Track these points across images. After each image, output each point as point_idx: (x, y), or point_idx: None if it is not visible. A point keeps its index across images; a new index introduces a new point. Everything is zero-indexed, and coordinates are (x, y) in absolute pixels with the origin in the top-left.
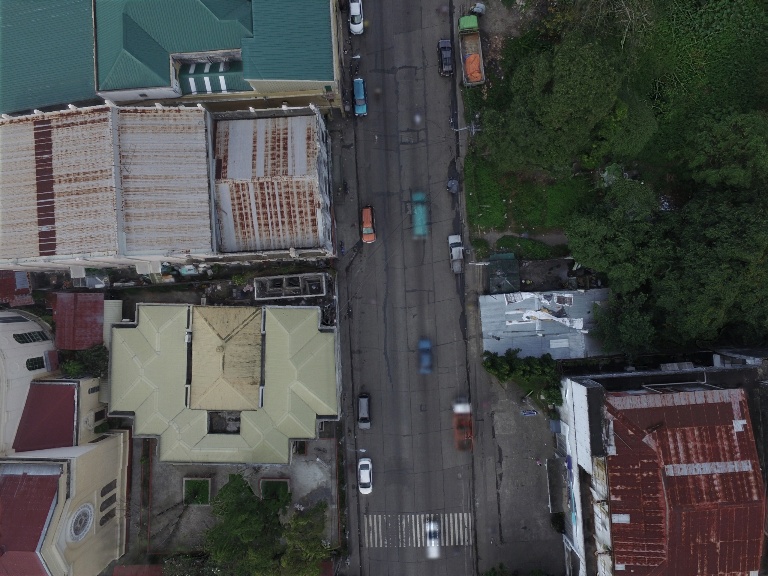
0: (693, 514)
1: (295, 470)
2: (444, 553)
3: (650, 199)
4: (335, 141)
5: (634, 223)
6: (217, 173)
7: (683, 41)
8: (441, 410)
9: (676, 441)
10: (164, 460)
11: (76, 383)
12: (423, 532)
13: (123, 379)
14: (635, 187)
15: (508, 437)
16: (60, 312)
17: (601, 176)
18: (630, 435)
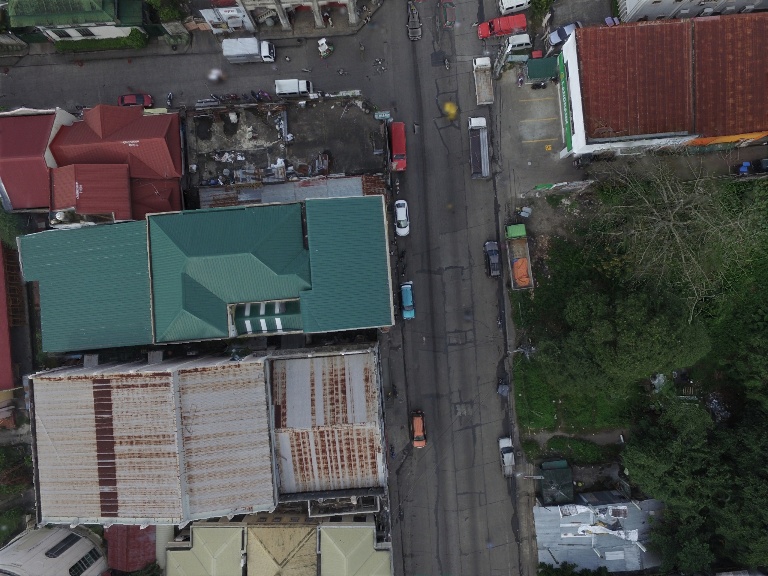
0: None
1: None
2: None
3: (705, 420)
4: (383, 343)
5: (692, 452)
6: (276, 421)
7: (729, 239)
8: None
9: None
10: None
11: None
12: None
13: None
14: (691, 411)
15: None
16: (112, 531)
17: (652, 383)
18: None
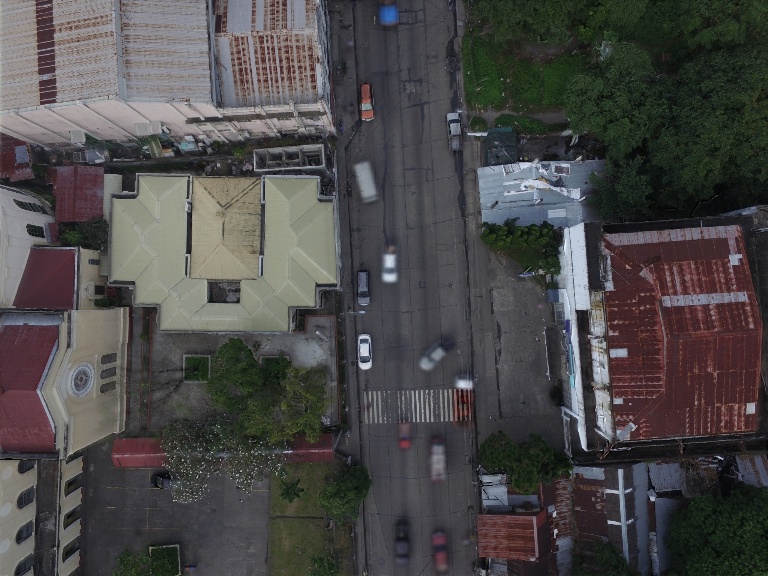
0: (690, 343)
1: (295, 348)
2: (443, 428)
3: (646, 64)
4: (334, 22)
5: (630, 83)
6: (217, 27)
7: None
8: (440, 287)
9: (673, 274)
10: (164, 329)
11: (76, 248)
12: (422, 408)
13: (123, 248)
14: (631, 50)
15: (507, 313)
16: (60, 186)
17: (598, 50)
18: (627, 270)
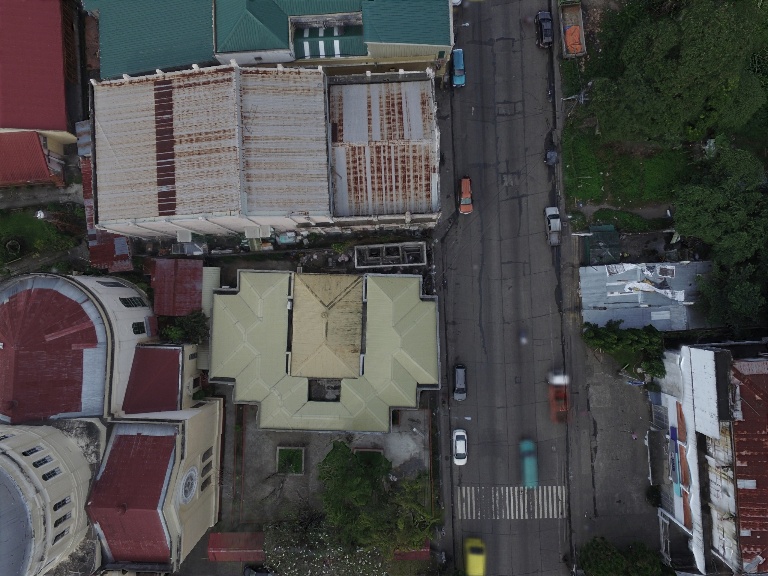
0: None
1: (388, 441)
2: (538, 526)
3: (759, 170)
4: None
5: (746, 193)
6: (333, 136)
7: None
8: (536, 382)
9: None
10: (264, 427)
11: (181, 347)
12: (517, 504)
13: (225, 345)
14: (745, 157)
15: (603, 410)
16: (159, 278)
17: (703, 148)
18: (757, 400)
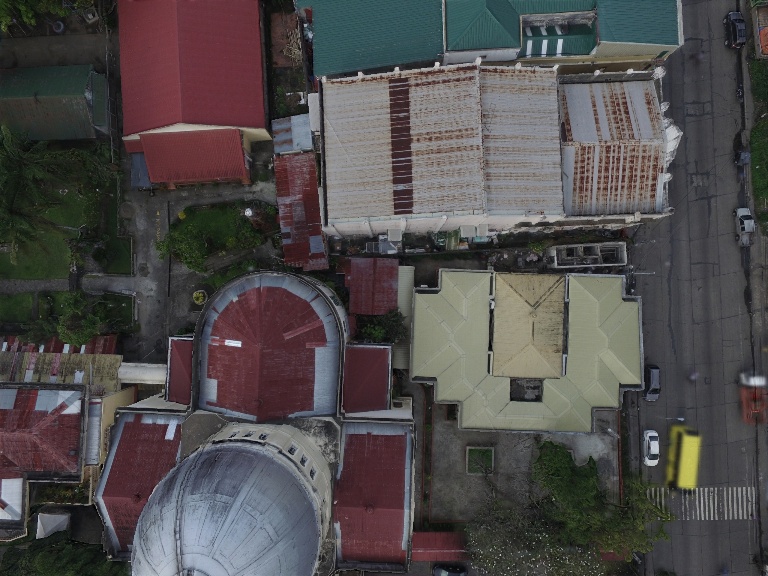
0: None
1: (576, 441)
2: (728, 527)
3: None
4: None
5: None
6: (563, 136)
7: None
8: (725, 383)
9: None
10: (466, 427)
11: (390, 347)
12: (707, 505)
13: (428, 344)
14: None
15: None
16: (356, 277)
17: None
18: None
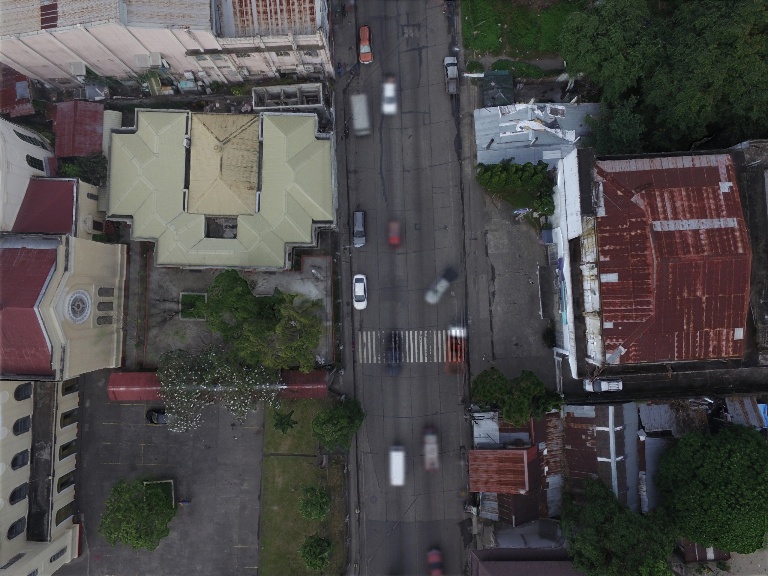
0: (680, 266)
1: (291, 288)
2: (437, 369)
3: (642, 5)
4: None
5: (626, 22)
6: None
7: None
8: (435, 229)
9: (664, 200)
10: (161, 263)
11: (75, 179)
12: (416, 348)
13: (122, 181)
14: None
15: (501, 256)
16: (60, 121)
17: None
18: (619, 196)
